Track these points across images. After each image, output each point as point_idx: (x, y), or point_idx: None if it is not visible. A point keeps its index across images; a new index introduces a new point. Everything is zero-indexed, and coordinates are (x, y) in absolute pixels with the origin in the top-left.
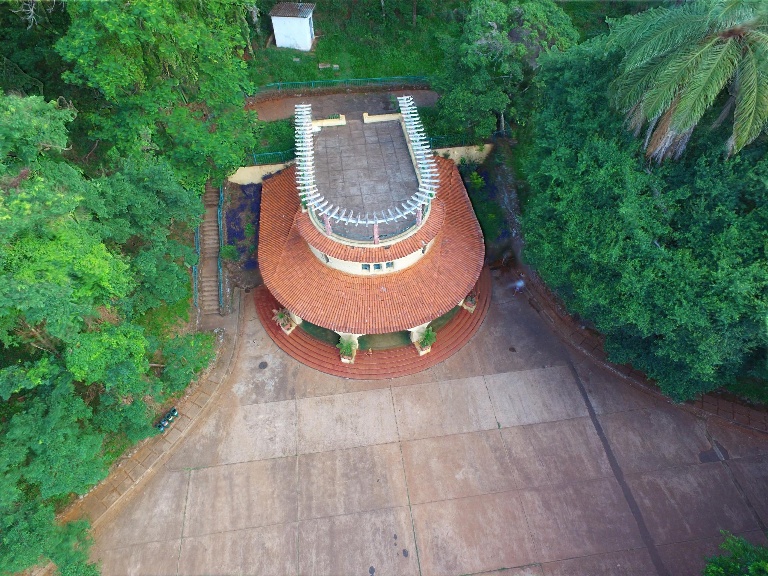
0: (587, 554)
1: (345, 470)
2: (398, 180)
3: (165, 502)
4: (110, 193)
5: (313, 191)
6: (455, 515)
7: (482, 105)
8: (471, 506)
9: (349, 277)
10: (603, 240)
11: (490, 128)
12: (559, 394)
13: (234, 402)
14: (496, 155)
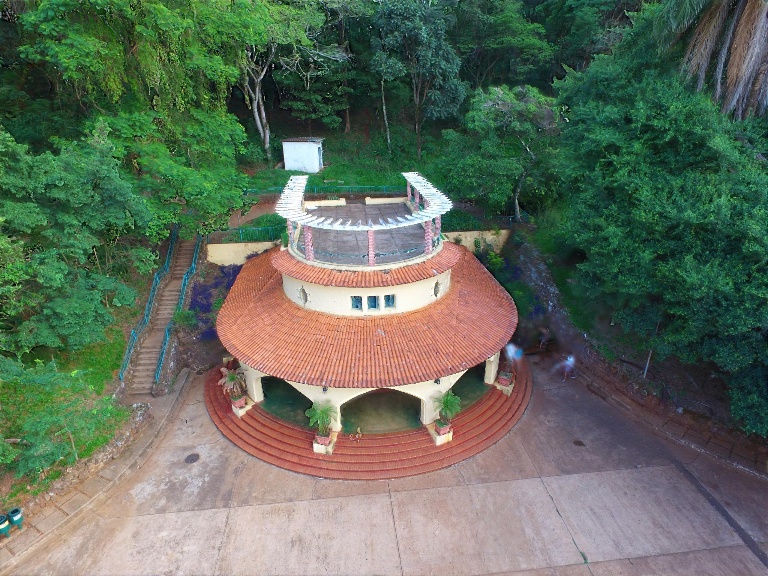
0: None
1: None
2: (402, 232)
3: None
4: (25, 158)
5: (295, 210)
6: None
7: (494, 168)
8: None
9: (333, 319)
10: (696, 202)
11: (506, 193)
12: (676, 507)
13: (126, 510)
14: (515, 234)
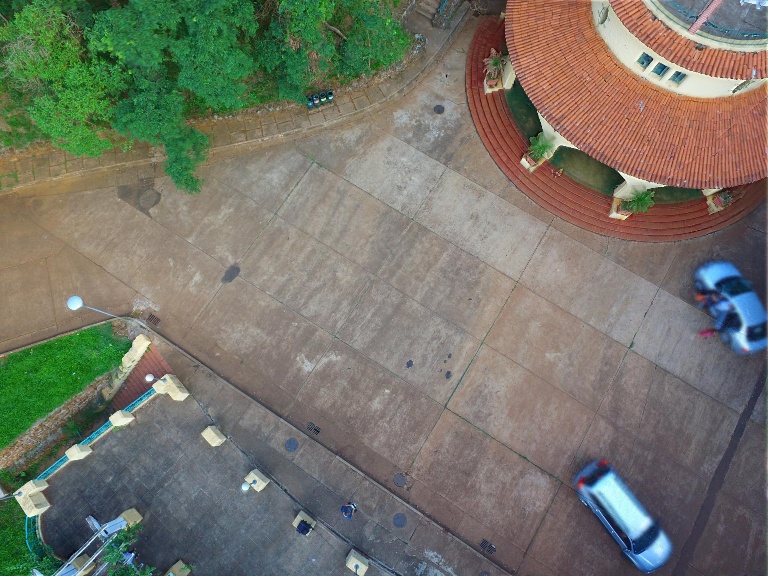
0: (614, 514)
1: (447, 267)
2: None
3: (278, 174)
4: None
5: None
6: (518, 383)
7: None
8: (539, 389)
9: (612, 61)
10: None
11: None
12: (728, 369)
13: (388, 127)
14: None
